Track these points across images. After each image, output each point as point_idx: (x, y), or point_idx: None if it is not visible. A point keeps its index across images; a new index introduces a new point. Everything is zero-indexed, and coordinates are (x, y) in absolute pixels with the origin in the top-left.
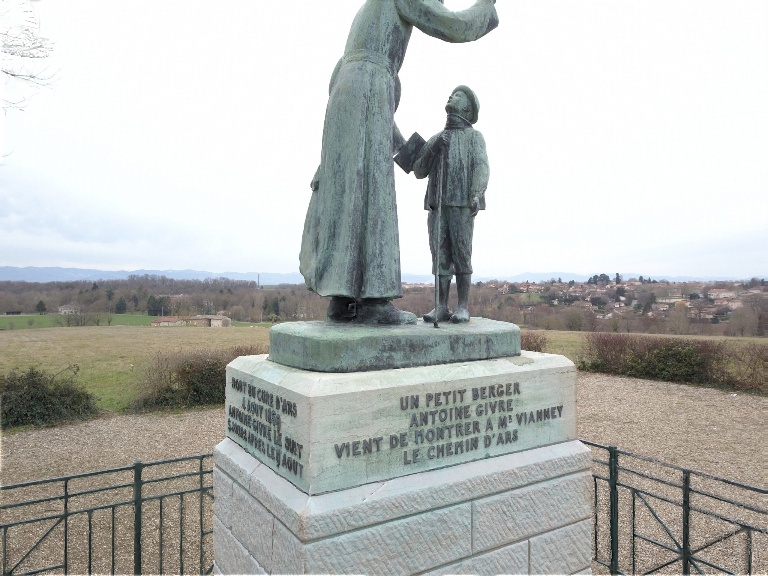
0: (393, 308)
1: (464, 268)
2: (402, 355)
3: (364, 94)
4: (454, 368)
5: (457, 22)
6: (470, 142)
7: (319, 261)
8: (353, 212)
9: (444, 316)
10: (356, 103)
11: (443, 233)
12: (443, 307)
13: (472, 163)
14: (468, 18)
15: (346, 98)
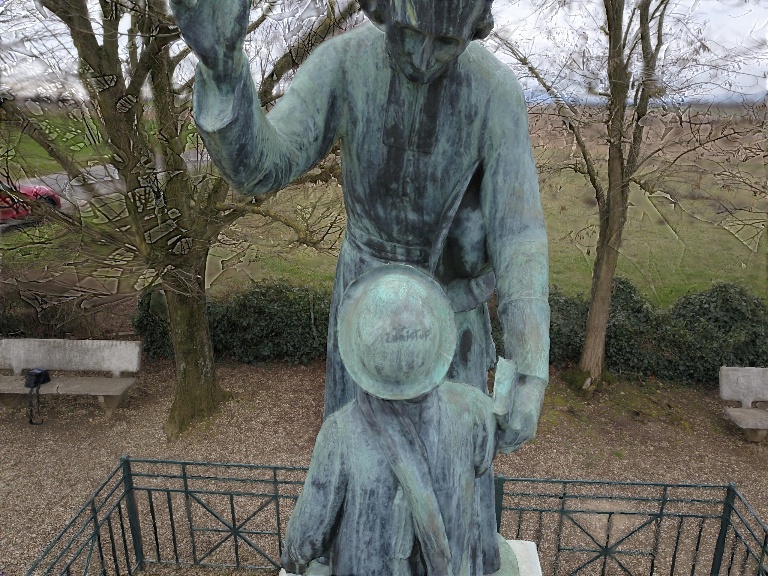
0: None
1: None
2: None
3: None
4: None
5: None
6: None
7: None
8: None
9: None
10: None
11: None
12: None
13: None
14: None
15: None
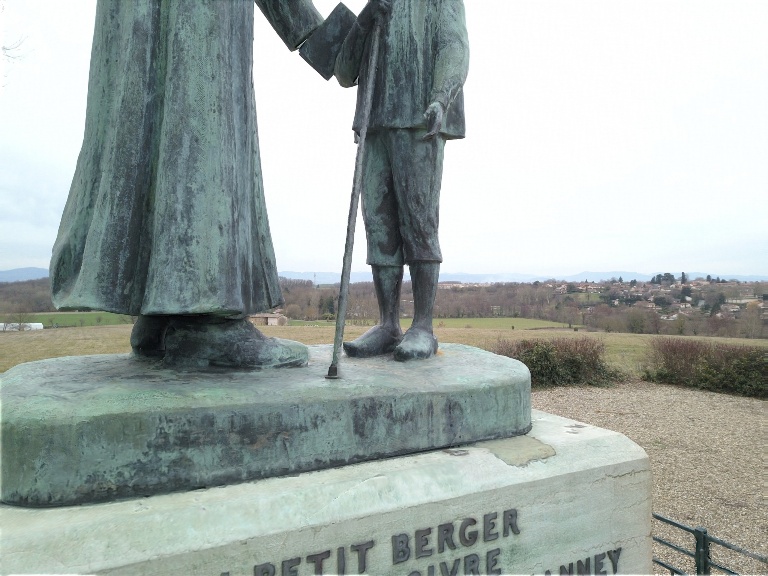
0: (249, 333)
1: (421, 251)
2: (218, 454)
3: None
4: (348, 486)
5: None
6: (431, 1)
7: (74, 232)
8: (120, 116)
9: (384, 344)
10: None
11: (381, 184)
12: (384, 327)
13: (434, 41)
14: None
15: None
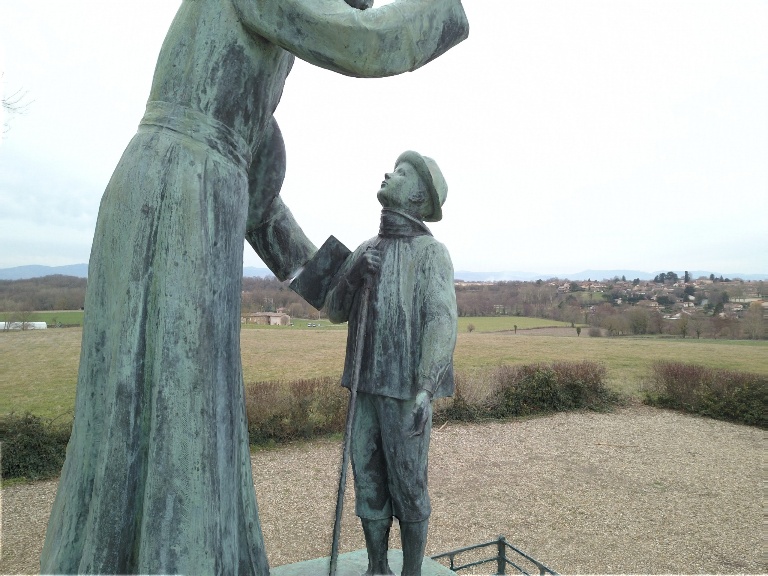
0: None
1: (410, 513)
2: None
3: (144, 206)
4: None
5: (359, 34)
6: (420, 267)
7: (59, 565)
8: (104, 485)
9: None
10: (131, 224)
11: (370, 441)
12: None
13: (423, 311)
14: (387, 24)
15: (114, 212)
